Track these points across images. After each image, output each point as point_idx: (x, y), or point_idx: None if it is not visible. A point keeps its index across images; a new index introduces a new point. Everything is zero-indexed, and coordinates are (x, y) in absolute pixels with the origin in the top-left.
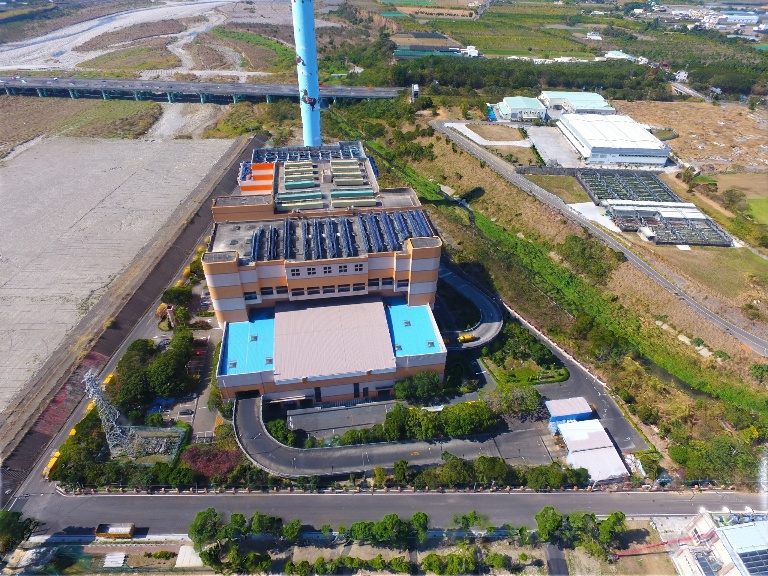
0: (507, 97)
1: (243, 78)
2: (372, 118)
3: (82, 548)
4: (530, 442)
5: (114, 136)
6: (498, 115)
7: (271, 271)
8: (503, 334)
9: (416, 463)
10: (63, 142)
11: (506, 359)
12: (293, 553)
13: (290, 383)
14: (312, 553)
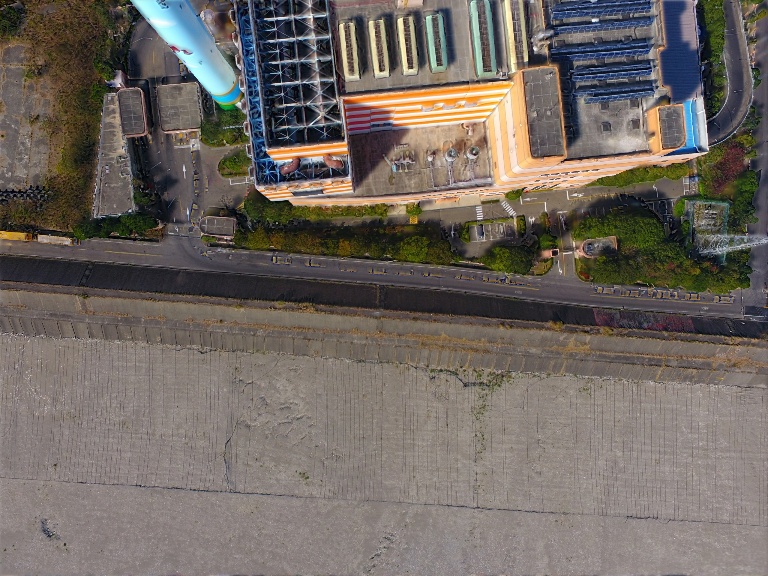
0: None
1: None
2: None
3: None
4: None
5: None
6: None
7: None
8: None
9: None
10: None
11: None
12: None
13: None
14: None
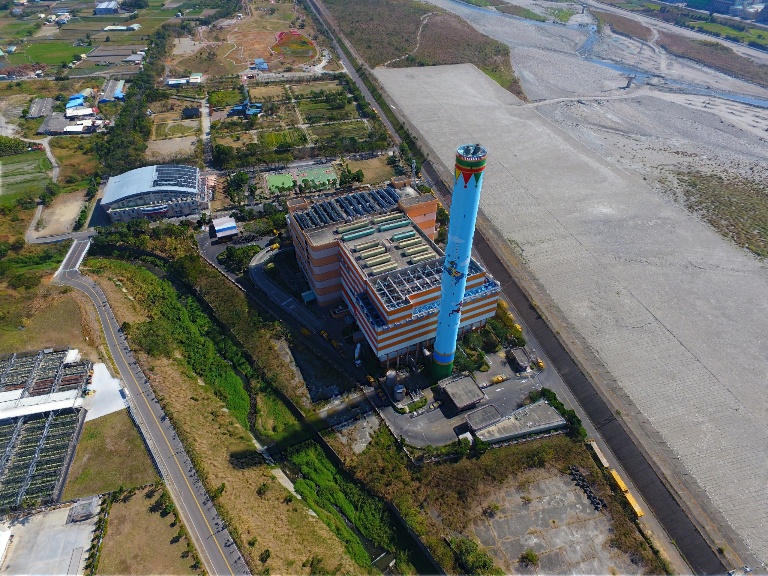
0: None
1: None
2: None
3: None
4: None
5: None
6: None
7: None
8: None
9: None
10: None
11: None
12: None
13: None
14: None
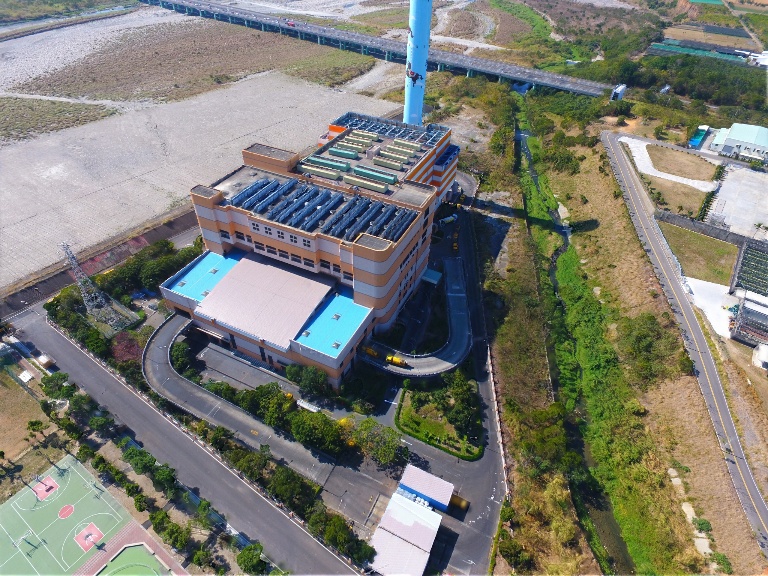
0: (739, 123)
1: (471, 49)
2: (553, 113)
3: (21, 358)
4: (364, 492)
5: (316, 81)
6: (708, 143)
7: (241, 218)
8: (441, 377)
9: (247, 440)
10: (278, 78)
11: (428, 404)
12: (106, 443)
13: (204, 318)
14: (115, 452)
